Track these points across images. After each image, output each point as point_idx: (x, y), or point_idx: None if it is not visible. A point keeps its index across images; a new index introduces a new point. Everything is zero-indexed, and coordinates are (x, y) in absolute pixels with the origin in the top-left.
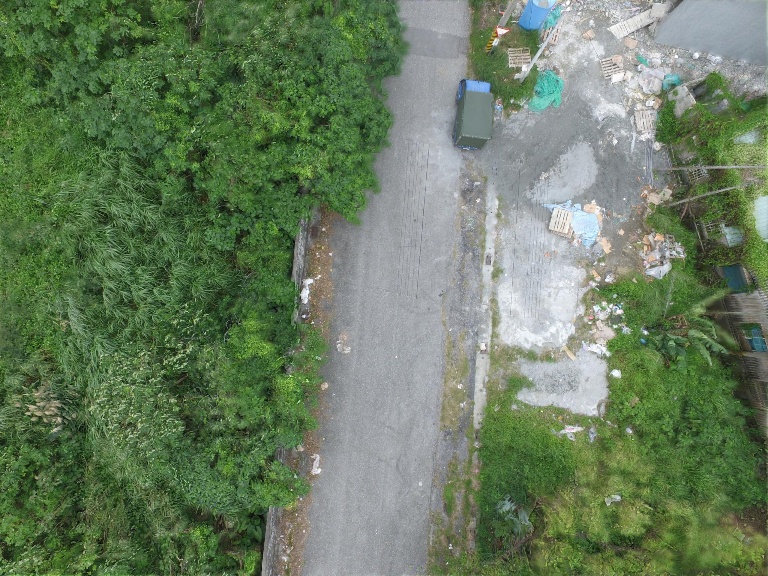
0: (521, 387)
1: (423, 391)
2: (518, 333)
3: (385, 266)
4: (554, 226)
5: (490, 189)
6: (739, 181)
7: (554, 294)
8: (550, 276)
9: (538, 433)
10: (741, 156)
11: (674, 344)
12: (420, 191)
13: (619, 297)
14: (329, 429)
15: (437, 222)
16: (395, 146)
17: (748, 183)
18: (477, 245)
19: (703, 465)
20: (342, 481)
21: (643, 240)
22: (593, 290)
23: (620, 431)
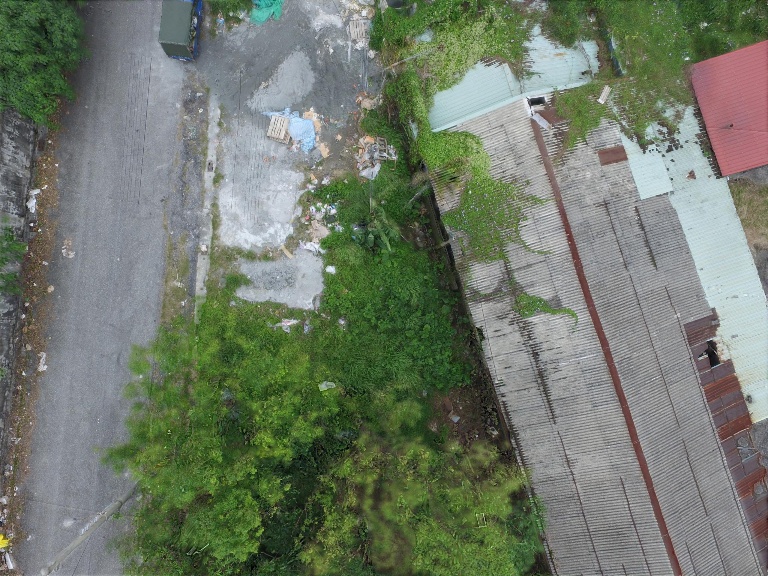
0: (238, 284)
1: (144, 290)
2: (238, 235)
3: (108, 174)
4: (271, 132)
5: (212, 100)
6: (417, 77)
7: (273, 197)
8: (269, 180)
9: (253, 326)
10: (421, 54)
11: (373, 237)
12: (142, 102)
13: (330, 197)
14: (55, 329)
15: (159, 132)
16: (118, 60)
17: (427, 79)
18: (199, 153)
19: (404, 349)
20: (67, 376)
21: (358, 144)
22: (308, 192)
23: (329, 321)
